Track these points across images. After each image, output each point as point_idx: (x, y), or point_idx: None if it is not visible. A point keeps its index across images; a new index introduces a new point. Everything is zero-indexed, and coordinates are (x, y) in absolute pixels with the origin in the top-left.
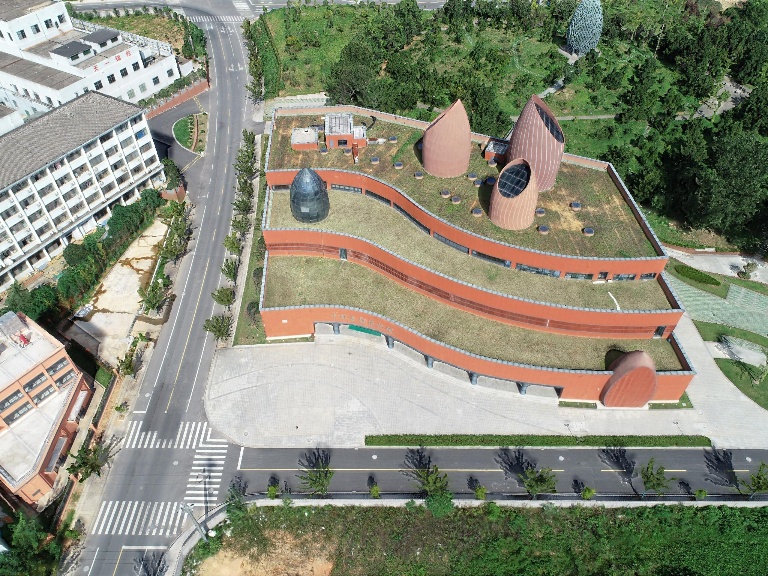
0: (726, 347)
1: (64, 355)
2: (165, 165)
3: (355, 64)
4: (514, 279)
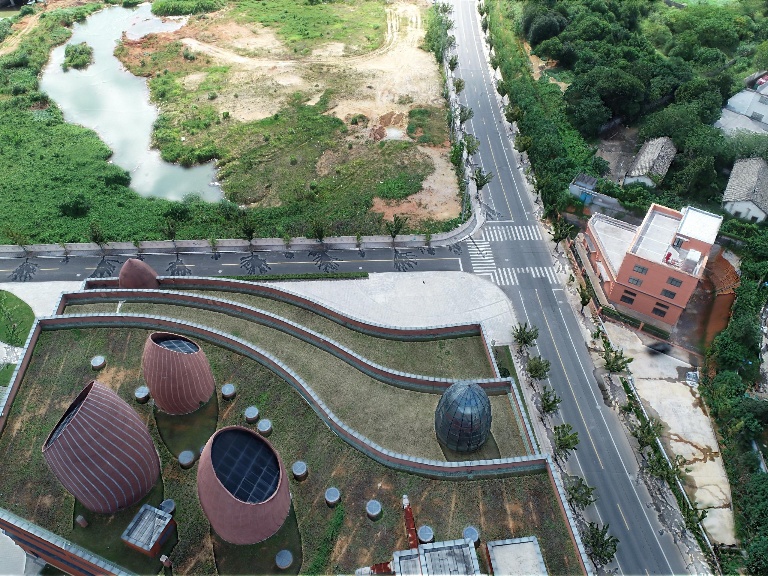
0: (8, 359)
1: None
2: None
3: None
4: None
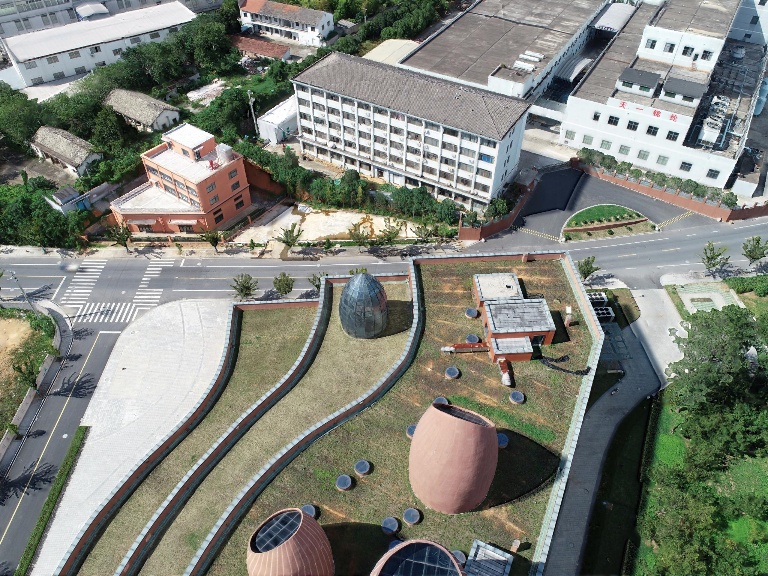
0: None
1: (196, 189)
2: (492, 203)
3: (761, 336)
4: (180, 575)
